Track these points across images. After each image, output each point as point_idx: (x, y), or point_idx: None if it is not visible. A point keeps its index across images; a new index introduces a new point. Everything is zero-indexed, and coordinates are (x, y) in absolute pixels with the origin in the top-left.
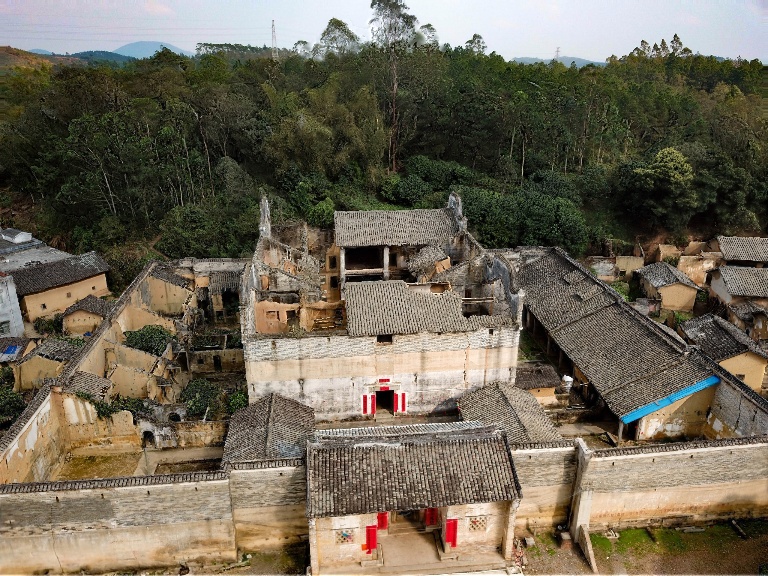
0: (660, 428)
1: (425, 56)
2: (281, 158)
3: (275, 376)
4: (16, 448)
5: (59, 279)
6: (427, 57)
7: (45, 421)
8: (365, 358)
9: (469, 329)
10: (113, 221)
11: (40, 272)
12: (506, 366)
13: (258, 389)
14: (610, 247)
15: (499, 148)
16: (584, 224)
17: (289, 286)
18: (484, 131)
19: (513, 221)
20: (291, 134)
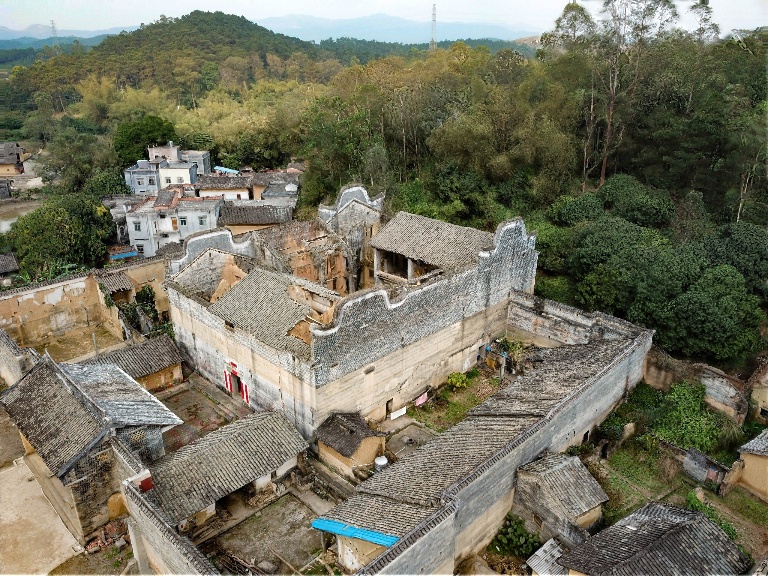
0: (357, 565)
1: (695, 46)
2: (443, 153)
3: (182, 323)
4: (32, 297)
5: (250, 219)
6: (698, 47)
7: (77, 293)
8: (222, 336)
9: (272, 345)
10: (310, 185)
11: (244, 211)
12: (309, 404)
13: (177, 329)
14: (761, 365)
15: (741, 182)
16: (759, 319)
17: (272, 262)
18: (696, 153)
19: (624, 279)
20: (449, 129)
